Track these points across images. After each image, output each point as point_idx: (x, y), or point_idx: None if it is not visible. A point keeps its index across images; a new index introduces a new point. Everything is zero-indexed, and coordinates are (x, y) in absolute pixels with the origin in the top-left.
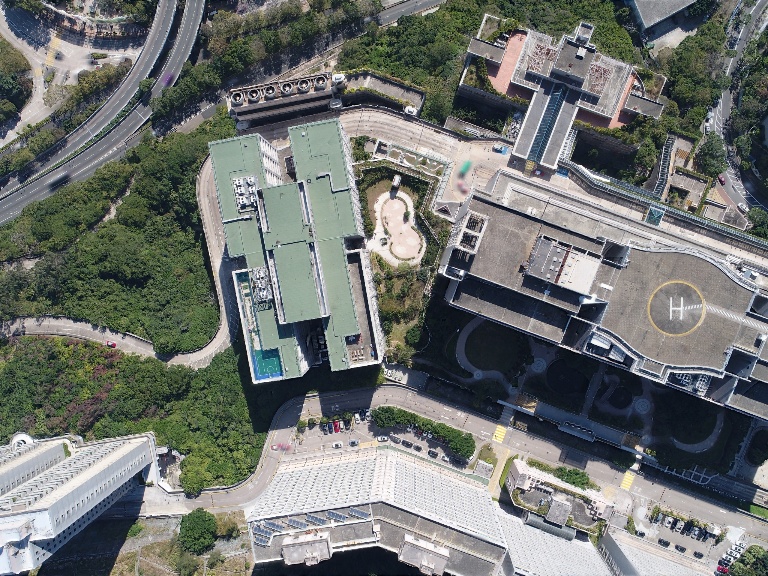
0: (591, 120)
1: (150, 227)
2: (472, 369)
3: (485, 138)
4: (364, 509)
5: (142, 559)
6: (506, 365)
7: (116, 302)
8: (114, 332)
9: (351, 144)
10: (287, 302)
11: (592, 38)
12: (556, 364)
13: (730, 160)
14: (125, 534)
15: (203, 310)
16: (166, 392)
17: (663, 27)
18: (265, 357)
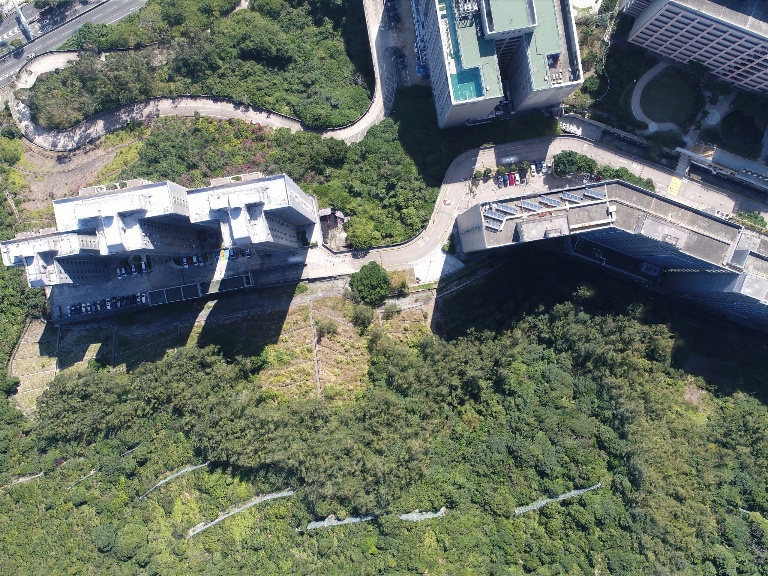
0: None
1: (285, 17)
2: (647, 121)
3: None
4: (599, 190)
5: (315, 311)
6: (681, 117)
7: (258, 83)
8: (258, 111)
9: None
10: (496, 10)
11: None
12: (730, 116)
13: None
14: (293, 291)
15: (351, 89)
16: (328, 154)
17: None
18: (461, 82)
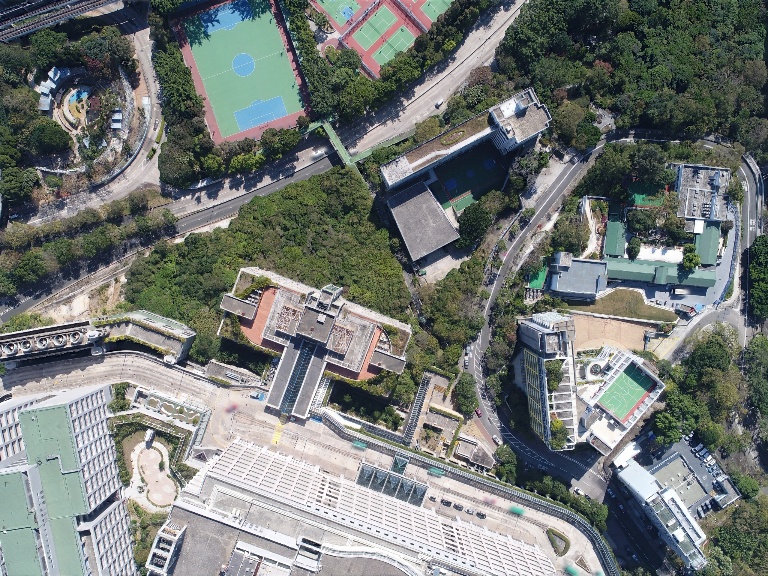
0: (342, 370)
1: None
2: None
3: (242, 385)
4: None
5: None
6: None
7: None
8: None
9: (113, 390)
10: None
11: (366, 266)
12: None
13: (487, 393)
14: None
15: None
16: None
17: (435, 255)
18: None
